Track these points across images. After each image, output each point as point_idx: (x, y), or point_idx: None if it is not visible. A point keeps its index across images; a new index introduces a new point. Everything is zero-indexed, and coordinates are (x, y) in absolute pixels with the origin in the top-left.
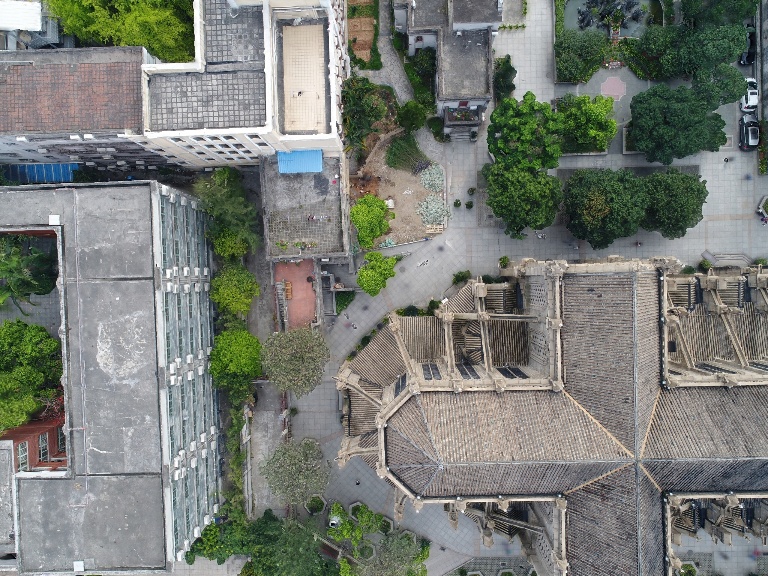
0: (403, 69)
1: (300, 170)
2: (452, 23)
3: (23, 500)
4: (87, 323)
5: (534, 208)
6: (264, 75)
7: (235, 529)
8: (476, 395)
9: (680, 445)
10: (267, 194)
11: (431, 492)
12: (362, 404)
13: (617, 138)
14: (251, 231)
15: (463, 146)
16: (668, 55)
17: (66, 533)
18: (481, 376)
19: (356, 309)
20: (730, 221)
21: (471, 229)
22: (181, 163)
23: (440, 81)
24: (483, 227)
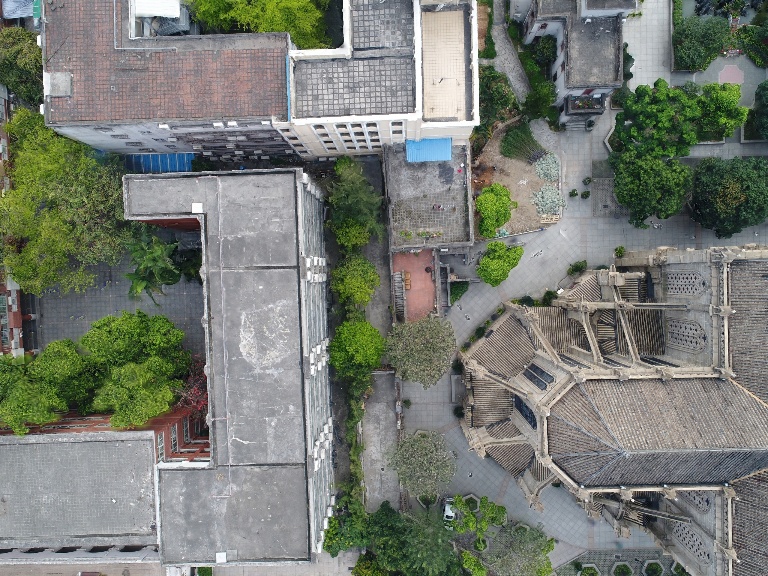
0: (517, 58)
1: (429, 159)
2: (580, 10)
3: (164, 491)
4: (230, 312)
5: (666, 196)
6: (411, 61)
7: (355, 521)
8: (640, 383)
9: None
10: (391, 183)
11: (595, 481)
12: (486, 395)
13: None
14: None
15: (578, 135)
16: None
17: (208, 524)
18: (629, 365)
19: (469, 300)
20: None
21: (586, 219)
22: (300, 152)
23: (570, 68)
24: (598, 217)
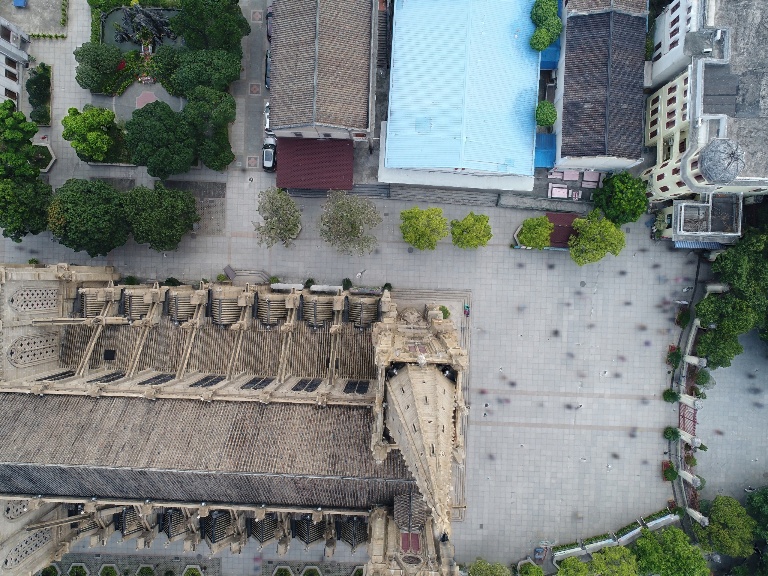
0: None
1: None
2: None
3: None
4: None
5: (3, 213)
6: None
7: None
8: None
9: None
10: None
11: None
12: None
13: None
14: None
15: None
16: (175, 74)
17: None
18: None
19: None
20: (252, 239)
21: None
22: None
23: None
24: None
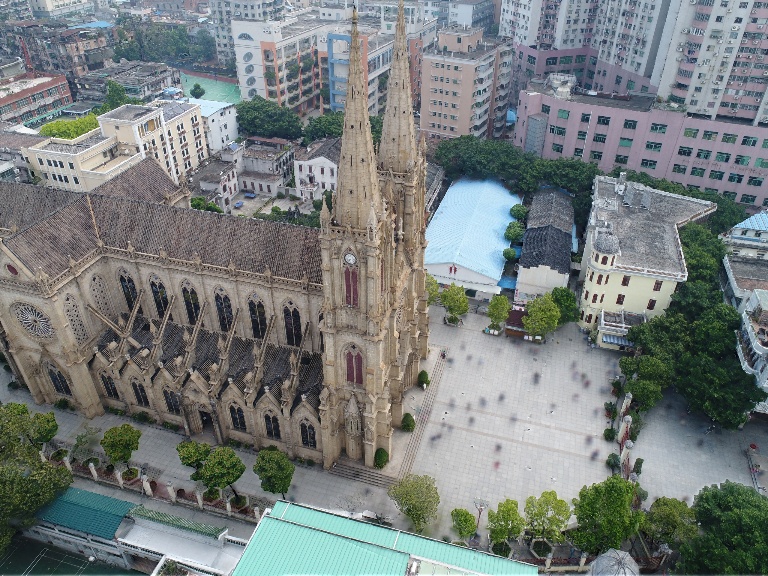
0: None
1: None
2: None
3: None
4: None
5: None
6: None
7: None
8: None
9: None
10: None
11: None
12: None
13: None
14: None
15: None
16: None
17: None
18: None
19: None
20: None
21: None
22: None
23: None
24: None
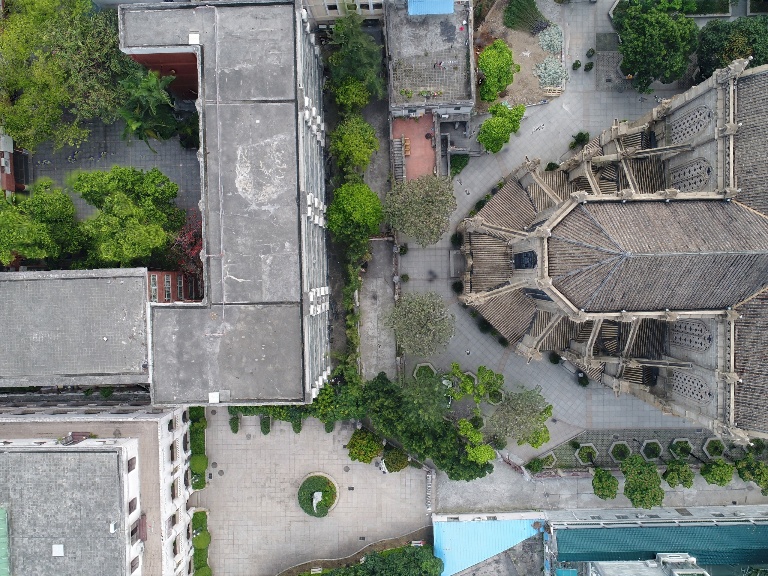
0: None
1: (430, 11)
2: None
3: (157, 330)
4: (226, 147)
5: (671, 52)
6: None
7: (351, 389)
8: (643, 205)
9: None
10: (392, 41)
11: (595, 305)
12: (485, 259)
13: None
14: None
15: (582, 7)
16: None
17: (201, 364)
18: None
19: (469, 174)
20: None
21: (589, 93)
22: None
23: None
24: (601, 91)
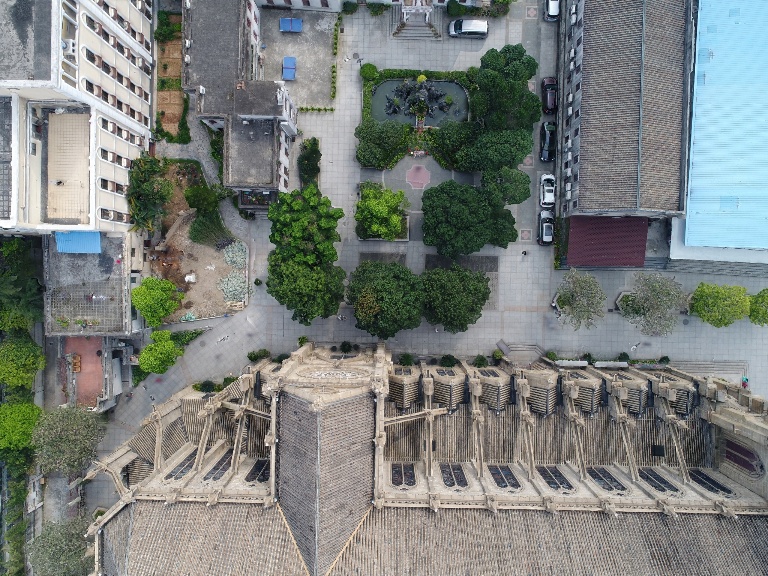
0: None
1: (78, 250)
2: None
3: None
4: None
5: (310, 301)
6: None
7: None
8: (192, 505)
9: (363, 573)
10: (51, 270)
11: None
12: None
13: (420, 225)
14: (34, 305)
15: (268, 224)
16: (462, 151)
17: None
18: (223, 476)
19: (155, 381)
20: (526, 312)
21: (272, 307)
22: None
23: (224, 169)
24: (284, 306)
